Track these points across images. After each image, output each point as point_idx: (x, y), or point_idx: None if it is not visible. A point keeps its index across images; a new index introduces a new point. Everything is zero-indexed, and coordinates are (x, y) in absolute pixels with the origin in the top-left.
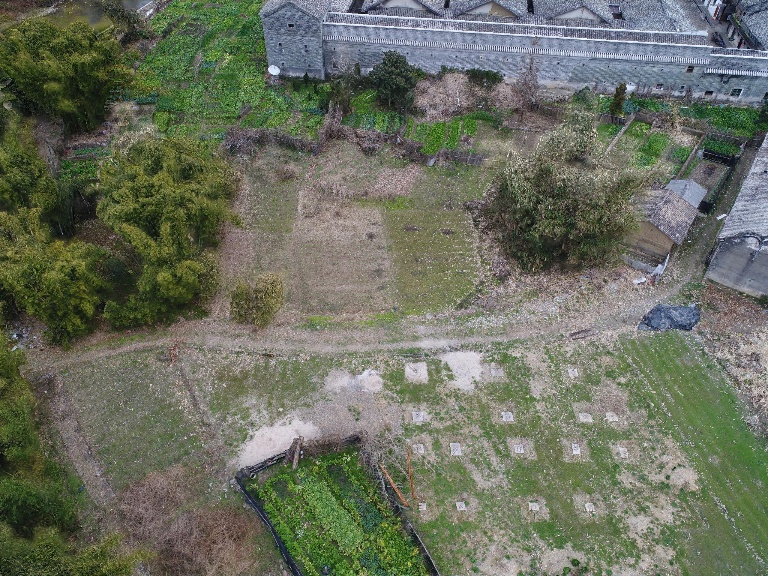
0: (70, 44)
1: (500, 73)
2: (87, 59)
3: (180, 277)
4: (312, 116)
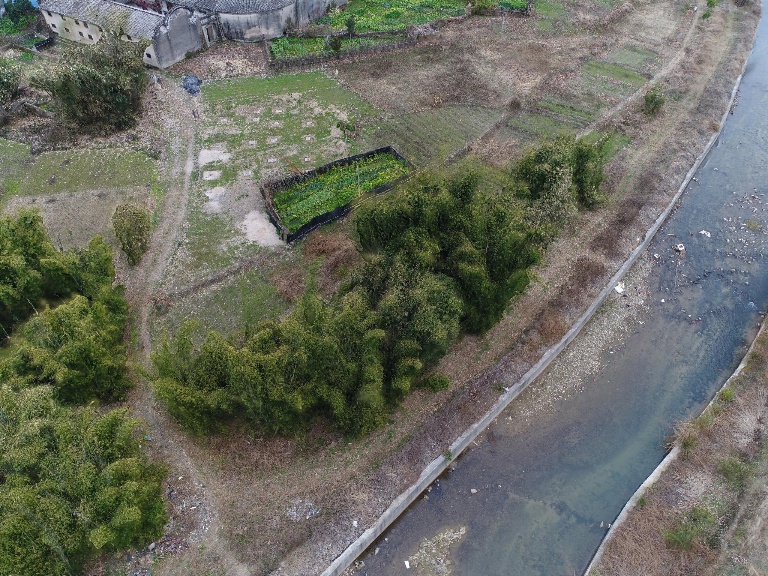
0: None
1: None
2: None
3: None
4: None
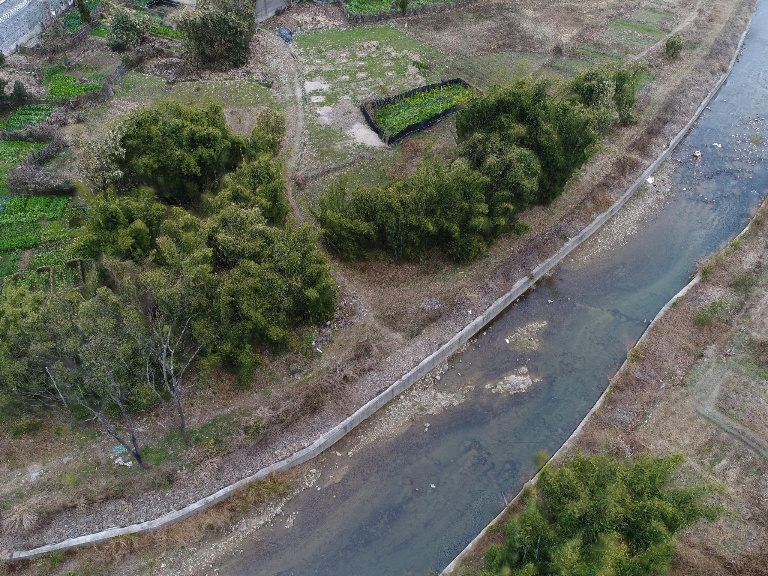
0: None
1: None
2: None
3: None
4: None
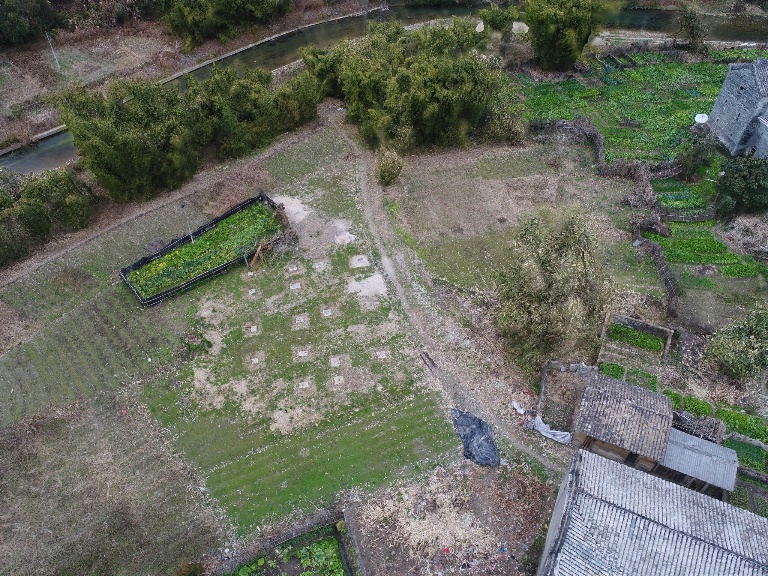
0: (567, 3)
1: None
2: (551, 12)
3: None
4: None
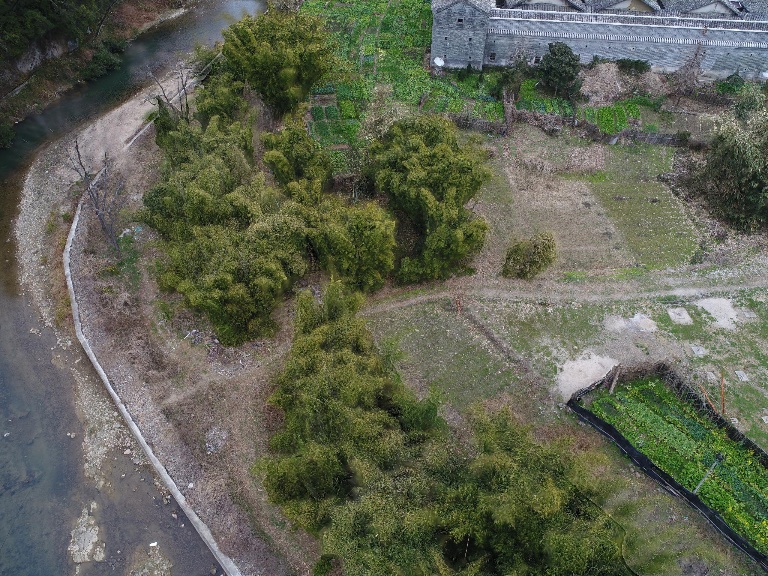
0: (292, 36)
1: (648, 62)
2: (316, 49)
3: (469, 235)
4: (484, 103)
